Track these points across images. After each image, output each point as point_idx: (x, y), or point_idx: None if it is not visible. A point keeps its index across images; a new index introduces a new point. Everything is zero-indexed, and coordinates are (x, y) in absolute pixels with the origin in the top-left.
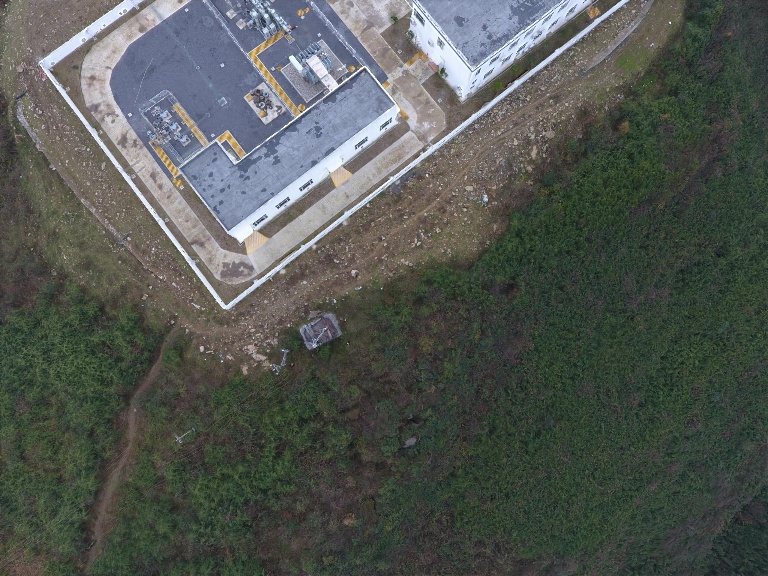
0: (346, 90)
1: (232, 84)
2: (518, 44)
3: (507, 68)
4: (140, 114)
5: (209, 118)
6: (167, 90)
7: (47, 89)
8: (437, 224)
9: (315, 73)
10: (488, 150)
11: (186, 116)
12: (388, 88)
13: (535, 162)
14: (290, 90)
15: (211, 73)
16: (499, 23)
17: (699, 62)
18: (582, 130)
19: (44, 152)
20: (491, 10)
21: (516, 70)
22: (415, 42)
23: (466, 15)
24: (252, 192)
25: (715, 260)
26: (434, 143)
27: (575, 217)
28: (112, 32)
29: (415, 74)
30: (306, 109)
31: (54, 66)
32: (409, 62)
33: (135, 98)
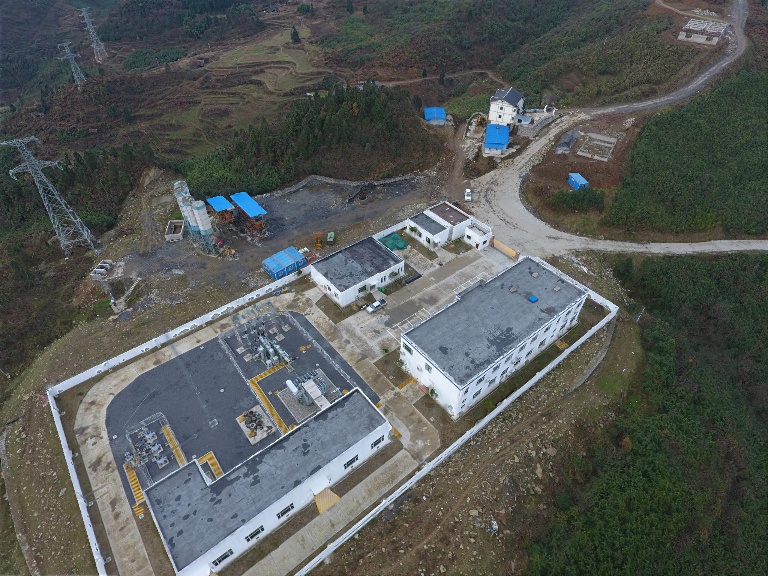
0: (338, 409)
1: (227, 407)
2: (500, 368)
3: (494, 390)
4: (125, 436)
5: (195, 439)
6: (161, 413)
7: (43, 414)
8: (440, 560)
9: (309, 395)
10: (488, 468)
11: (172, 437)
12: (380, 408)
13: (543, 482)
14: (283, 411)
15: (209, 397)
16: (479, 351)
17: (674, 383)
18: (584, 447)
19: (5, 478)
20: (471, 342)
21: (503, 390)
22: (405, 369)
23: (449, 346)
24: (220, 519)
25: None
26: (429, 461)
27: (607, 550)
28: (128, 365)
29: (406, 396)
30: (296, 427)
31: (60, 393)
32: (400, 386)
33: (127, 421)
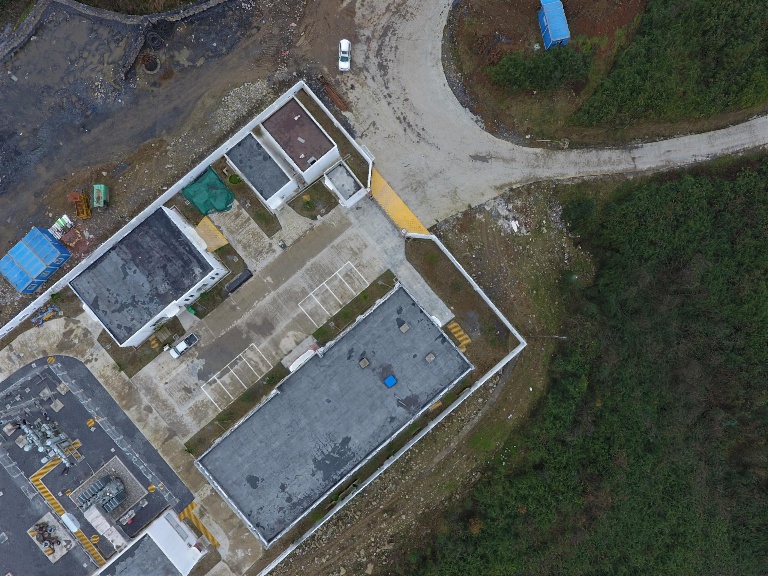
0: (127, 559)
1: (13, 515)
2: None
3: None
4: None
5: None
6: None
7: None
8: None
9: None
10: None
11: None
12: (195, 510)
13: (373, 573)
14: (81, 518)
15: None
16: (300, 481)
17: (565, 433)
18: (429, 526)
19: None
20: (290, 465)
21: None
22: None
23: (261, 473)
24: None
25: (615, 564)
26: (249, 575)
27: None
28: None
29: None
30: None
31: None
32: None
33: None
